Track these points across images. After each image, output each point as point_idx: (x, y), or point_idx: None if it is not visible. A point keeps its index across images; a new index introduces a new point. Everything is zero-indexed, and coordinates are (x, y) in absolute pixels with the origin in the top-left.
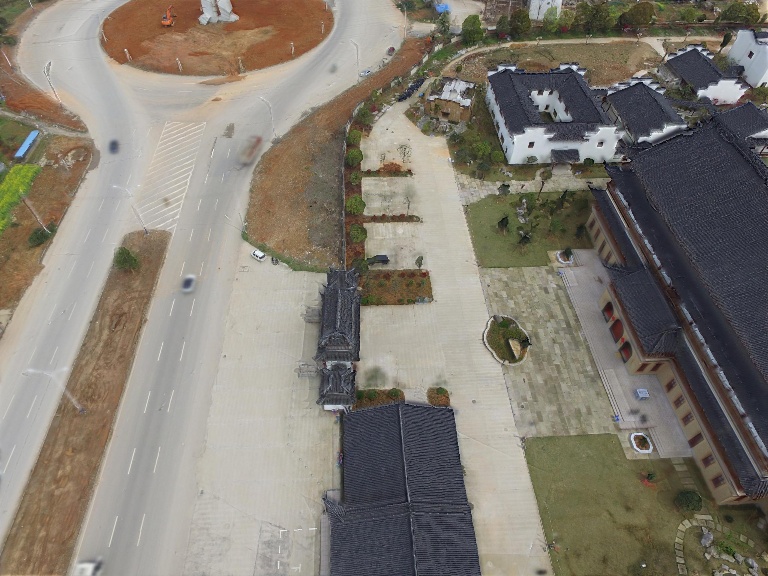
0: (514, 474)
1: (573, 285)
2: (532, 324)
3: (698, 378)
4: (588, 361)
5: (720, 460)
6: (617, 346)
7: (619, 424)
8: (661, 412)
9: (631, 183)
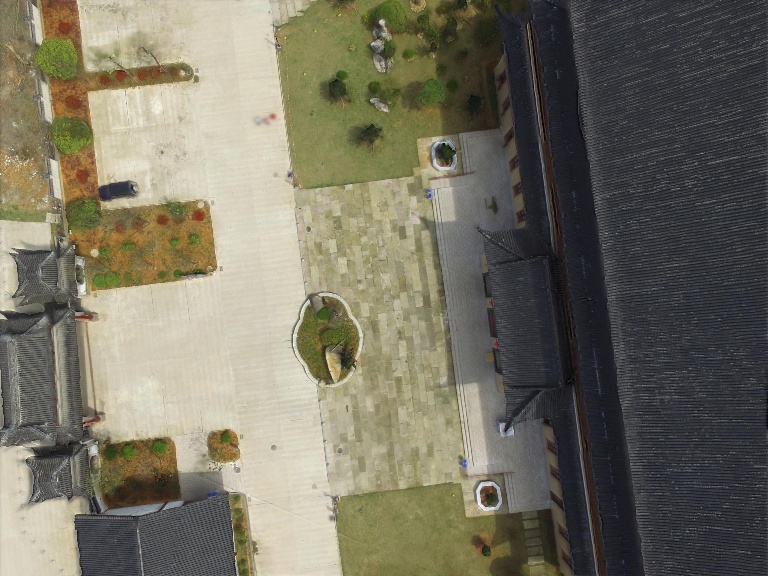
0: (319, 547)
1: (447, 220)
2: (371, 305)
3: (572, 459)
4: (444, 368)
5: (571, 552)
6: (491, 343)
7: (467, 468)
8: (527, 448)
9: (566, 36)
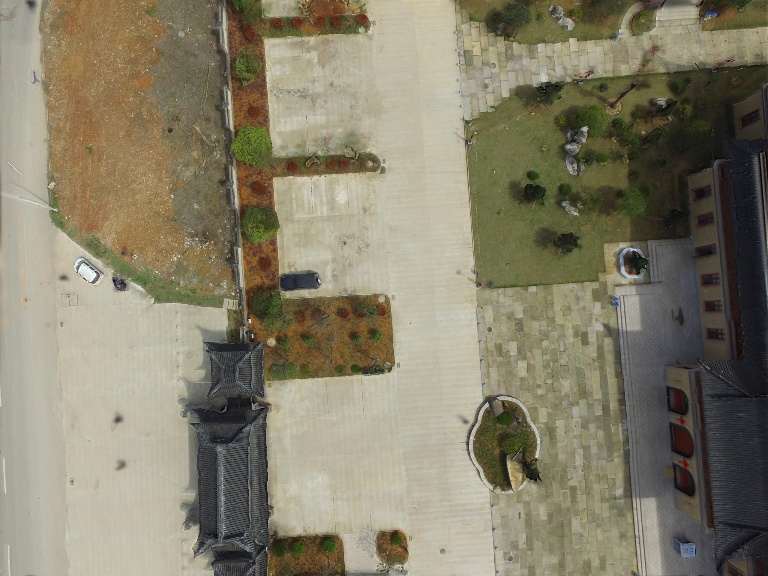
0: None
1: (632, 329)
2: (549, 411)
3: None
4: (621, 480)
5: None
6: (673, 458)
7: None
8: (703, 568)
9: None
